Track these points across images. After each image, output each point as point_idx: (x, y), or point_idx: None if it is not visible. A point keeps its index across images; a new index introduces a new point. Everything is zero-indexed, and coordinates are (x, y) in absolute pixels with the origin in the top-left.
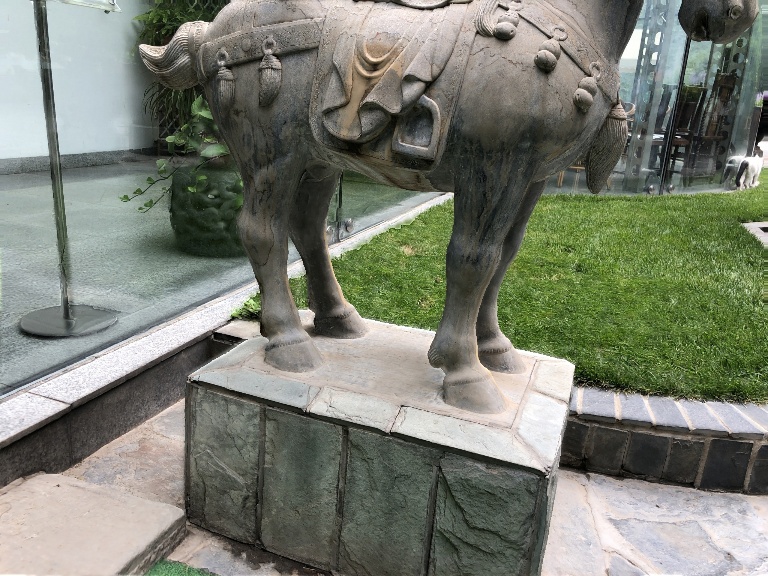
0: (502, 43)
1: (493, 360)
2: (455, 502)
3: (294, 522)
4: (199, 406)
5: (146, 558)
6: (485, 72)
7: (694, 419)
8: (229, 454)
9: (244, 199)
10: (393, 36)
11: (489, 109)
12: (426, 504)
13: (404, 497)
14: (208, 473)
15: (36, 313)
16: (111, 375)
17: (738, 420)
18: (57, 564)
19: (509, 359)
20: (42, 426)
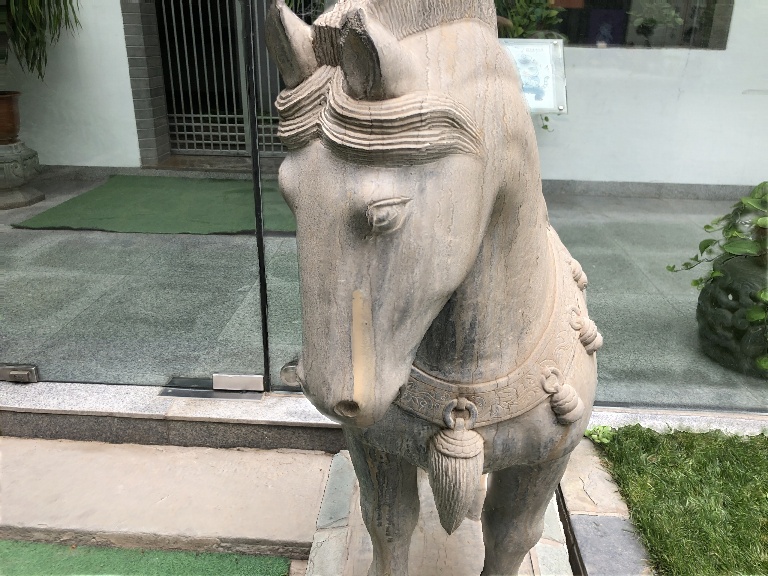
0: None
1: None
2: None
3: None
4: None
5: (275, 546)
6: None
7: None
8: None
9: None
10: None
11: None
12: None
13: None
14: None
15: None
16: None
17: None
18: (247, 508)
19: None
20: None
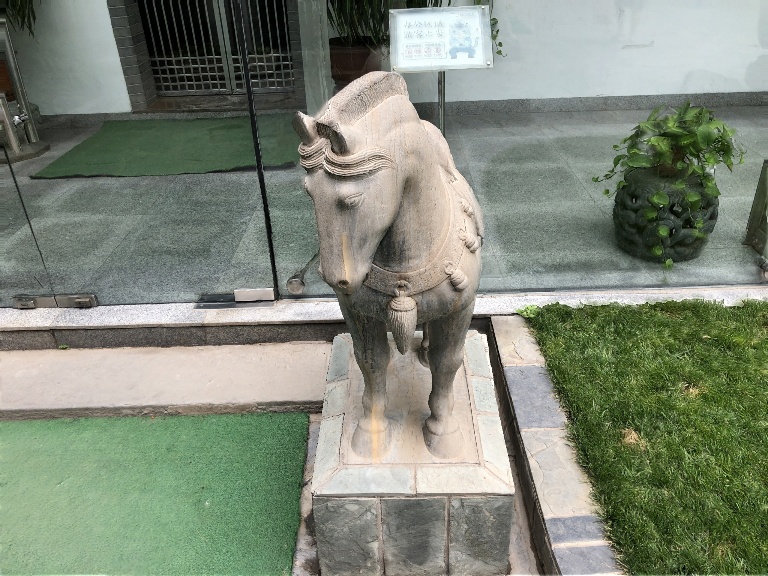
0: None
1: (427, 434)
2: None
3: None
4: None
5: (297, 405)
6: None
7: None
8: None
9: None
10: None
11: None
12: None
13: None
14: None
15: None
16: None
17: None
18: (274, 382)
19: (434, 441)
20: (338, 322)
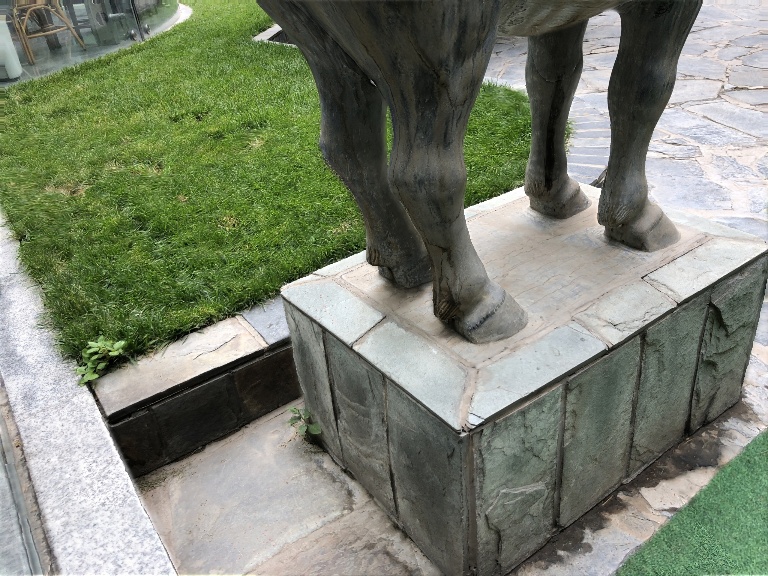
0: None
1: (579, 201)
2: (720, 325)
3: (592, 473)
4: (487, 450)
5: None
6: None
7: None
8: (526, 471)
9: (414, 132)
10: None
11: None
12: (697, 347)
13: (684, 356)
14: (505, 515)
15: None
16: (153, 574)
17: (584, 169)
18: None
19: None
20: None
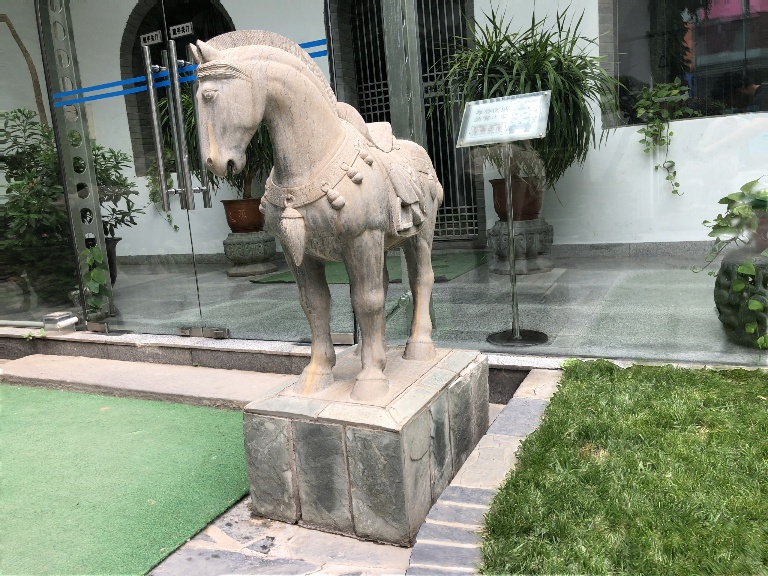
0: None
1: None
2: None
3: None
4: None
5: None
6: None
7: (429, 572)
8: None
9: None
10: None
11: None
12: None
13: None
14: None
15: (521, 330)
16: None
17: None
18: None
19: None
20: None
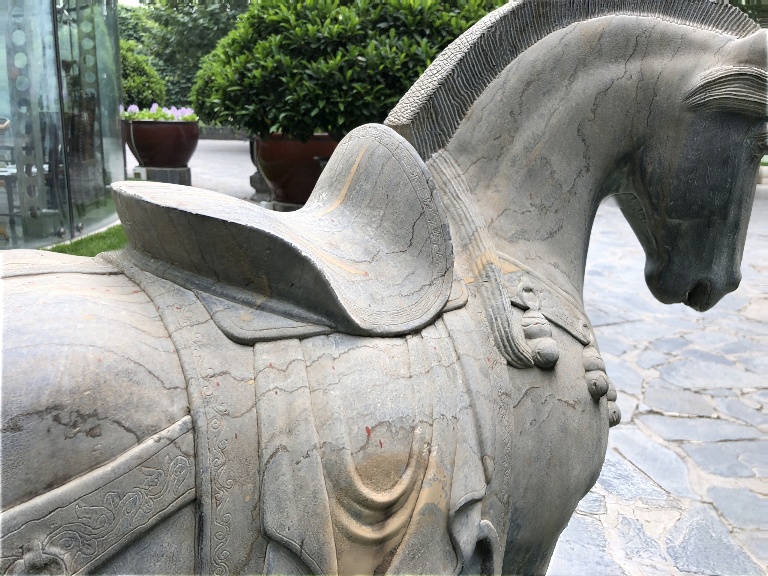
0: (549, 375)
1: None
2: None
3: None
4: None
5: None
6: (544, 434)
7: None
8: None
9: None
10: (402, 426)
11: (558, 492)
12: None
13: None
14: None
15: None
16: None
17: None
18: None
19: None
20: None
